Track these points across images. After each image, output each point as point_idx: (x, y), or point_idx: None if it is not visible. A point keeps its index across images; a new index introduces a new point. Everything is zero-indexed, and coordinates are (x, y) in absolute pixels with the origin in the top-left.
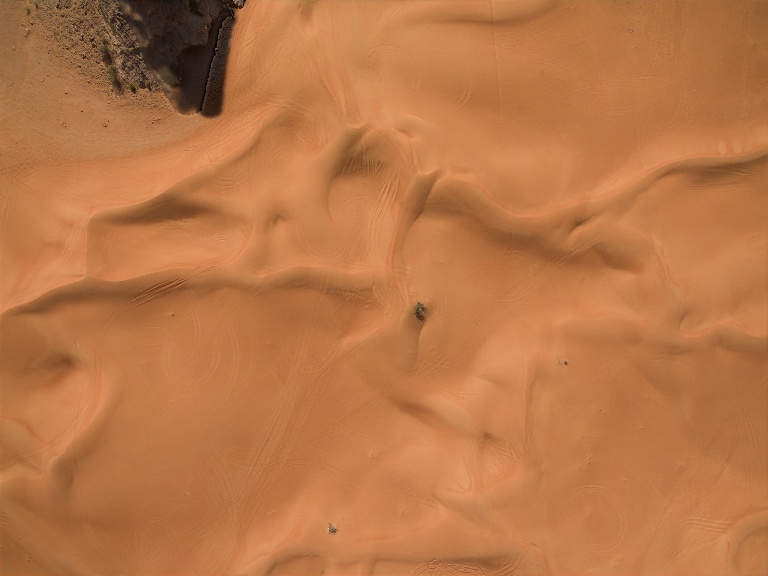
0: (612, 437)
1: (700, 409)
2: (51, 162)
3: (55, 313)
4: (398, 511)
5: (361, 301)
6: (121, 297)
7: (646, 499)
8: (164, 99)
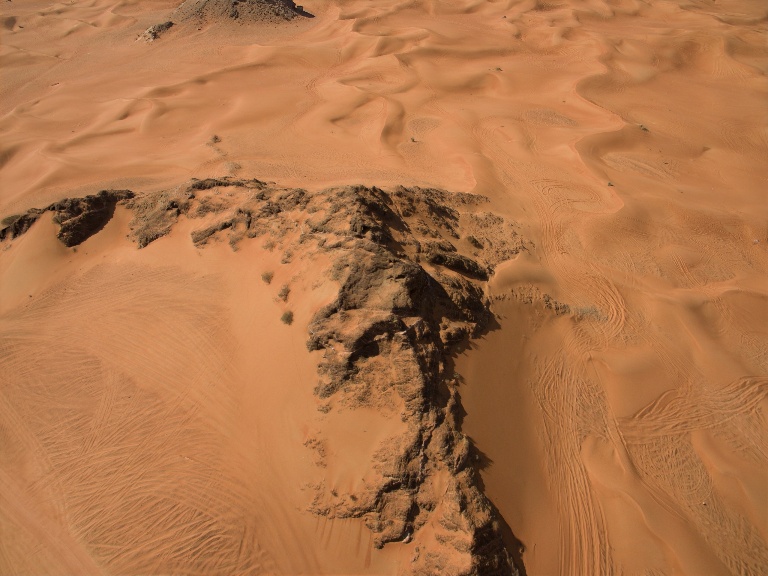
0: None
1: None
2: (297, 35)
3: (362, 30)
4: None
5: (419, 5)
6: (371, 21)
7: None
8: None
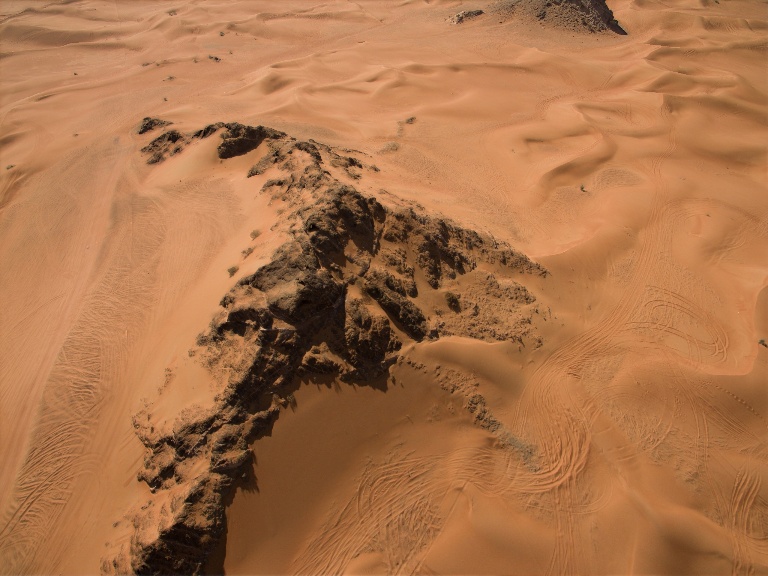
0: None
1: None
2: None
3: None
4: None
5: None
6: (680, 52)
7: None
8: (613, 32)
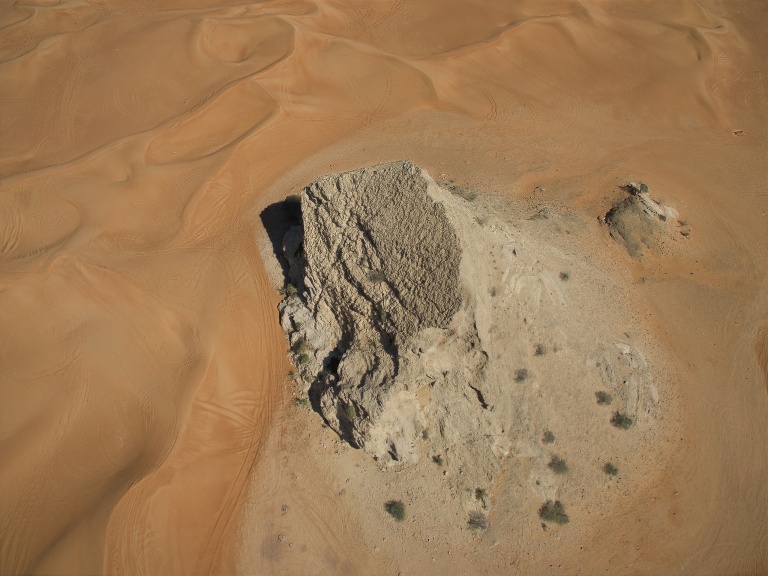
0: None
1: None
2: (353, 131)
3: None
4: None
5: None
6: None
7: None
8: None
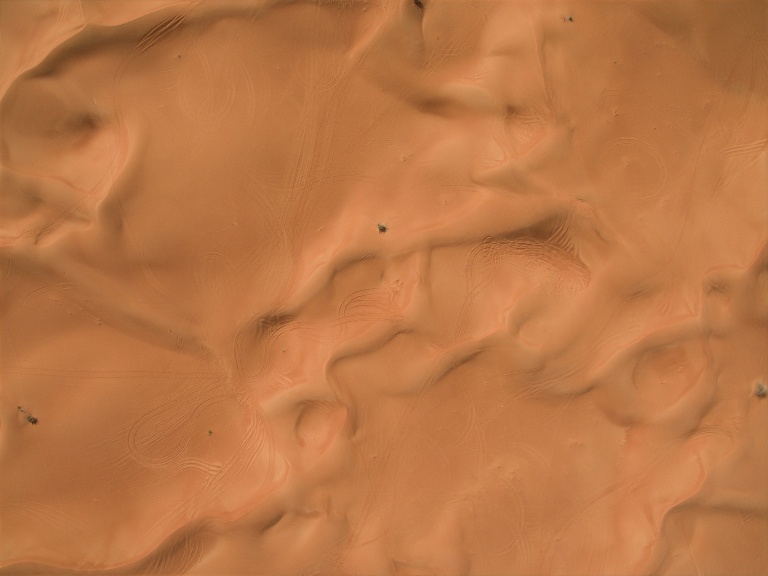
0: (633, 88)
1: (713, 42)
2: None
3: (66, 73)
4: (441, 201)
5: (357, 4)
6: (125, 42)
7: (680, 141)
8: None
